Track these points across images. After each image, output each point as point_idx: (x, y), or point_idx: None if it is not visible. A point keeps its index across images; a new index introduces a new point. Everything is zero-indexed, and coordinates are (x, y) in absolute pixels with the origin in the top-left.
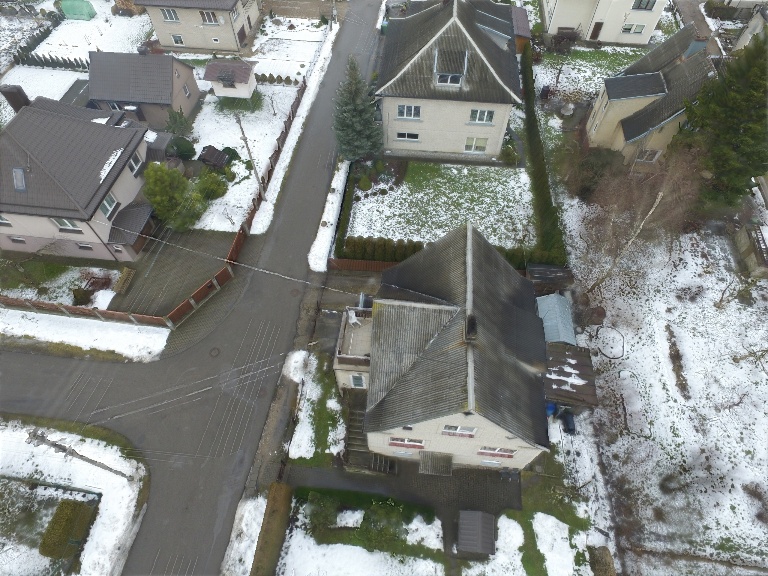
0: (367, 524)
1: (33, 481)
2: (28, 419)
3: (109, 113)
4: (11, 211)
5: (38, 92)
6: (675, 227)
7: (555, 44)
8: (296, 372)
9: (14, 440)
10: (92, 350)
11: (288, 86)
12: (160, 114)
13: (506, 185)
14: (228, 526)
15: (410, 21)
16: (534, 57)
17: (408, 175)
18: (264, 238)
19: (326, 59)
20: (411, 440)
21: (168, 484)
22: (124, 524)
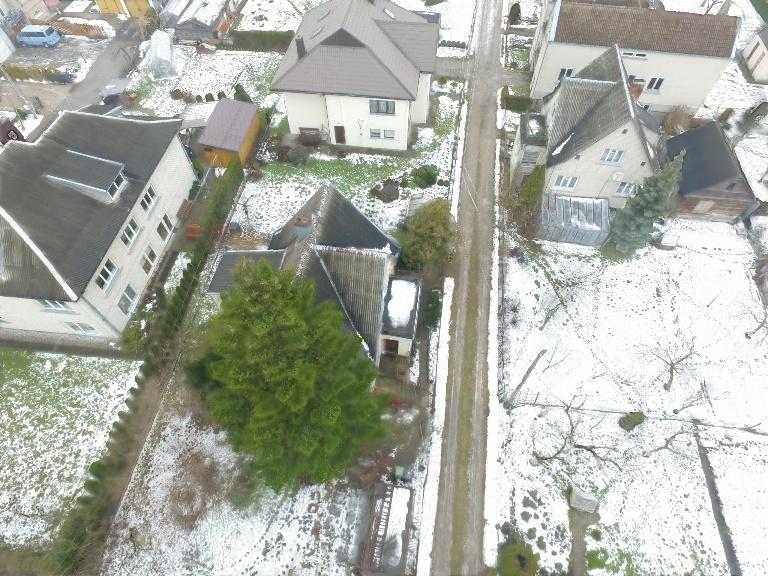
0: None
1: None
2: None
3: None
4: None
5: None
6: (300, 472)
7: (281, 154)
8: None
9: None
10: None
11: None
12: None
13: (102, 392)
14: None
15: None
16: (256, 170)
17: None
18: None
19: None
20: None
21: None
22: None
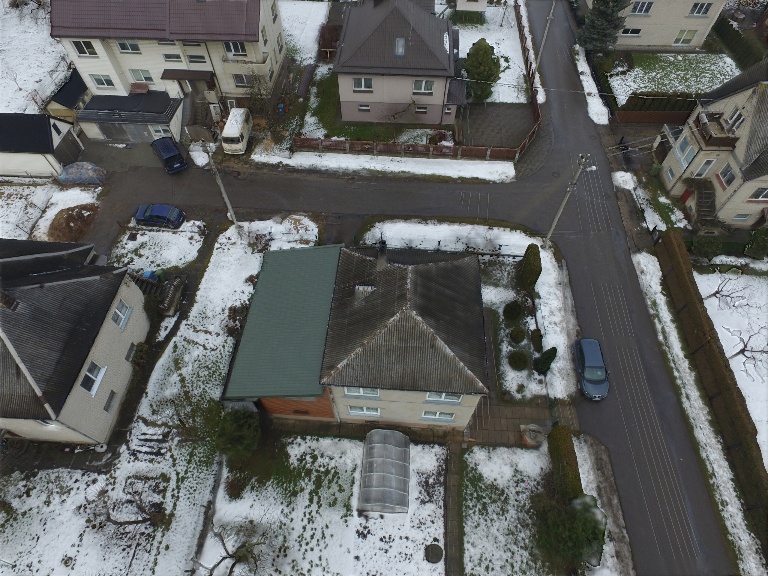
0: (762, 238)
1: (471, 252)
2: (441, 218)
3: None
4: (391, 73)
5: (292, 16)
6: None
7: None
8: (625, 183)
9: (440, 230)
10: (460, 177)
11: (499, 6)
12: None
13: (717, 65)
14: (632, 268)
15: None
16: None
17: (636, 62)
18: (547, 105)
19: None
20: (762, 197)
21: (573, 248)
22: (555, 271)
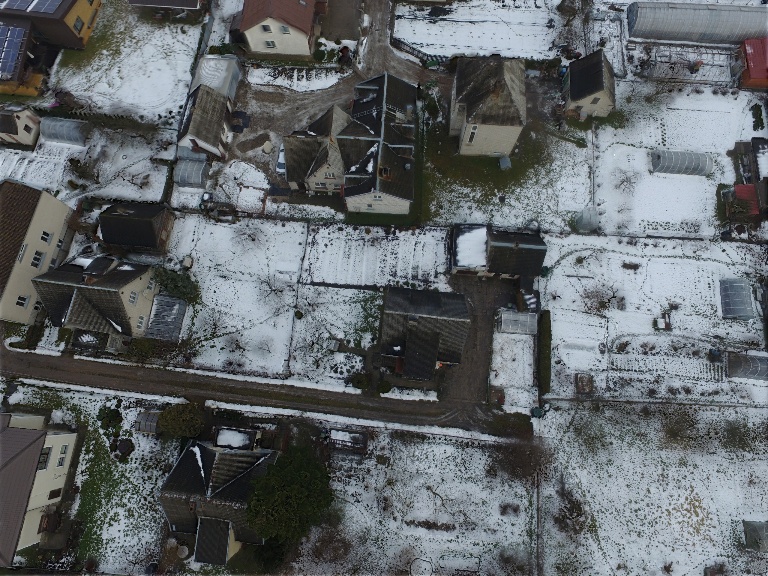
0: None
1: None
2: None
3: None
4: None
5: None
6: None
7: None
8: None
9: None
10: None
11: None
12: None
13: None
14: None
15: None
16: (83, 566)
17: None
18: None
19: None
20: None
21: None
22: None
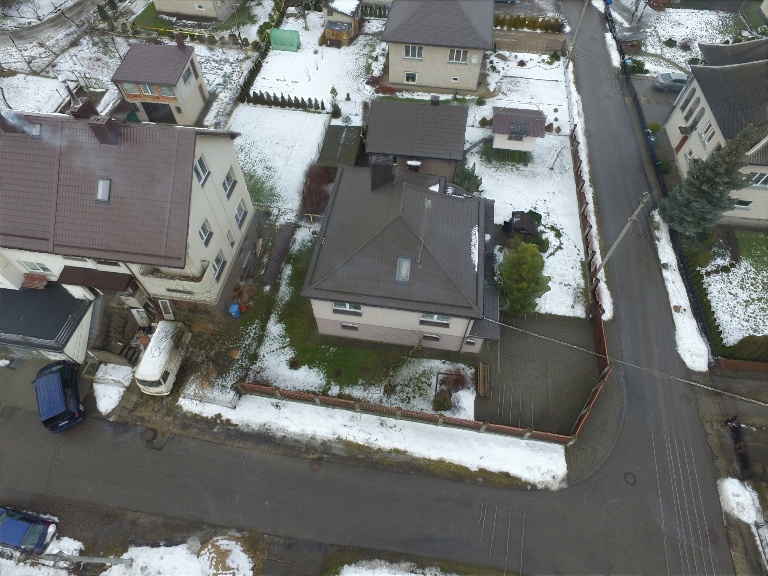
0: None
1: None
2: (447, 566)
3: (437, 178)
4: (387, 305)
5: (277, 136)
6: None
7: None
8: (742, 509)
9: None
10: (482, 471)
11: (550, 134)
12: (439, 169)
13: None
14: None
15: (735, 72)
16: None
17: (742, 248)
18: (615, 326)
19: (577, 102)
20: None
21: None
22: None
